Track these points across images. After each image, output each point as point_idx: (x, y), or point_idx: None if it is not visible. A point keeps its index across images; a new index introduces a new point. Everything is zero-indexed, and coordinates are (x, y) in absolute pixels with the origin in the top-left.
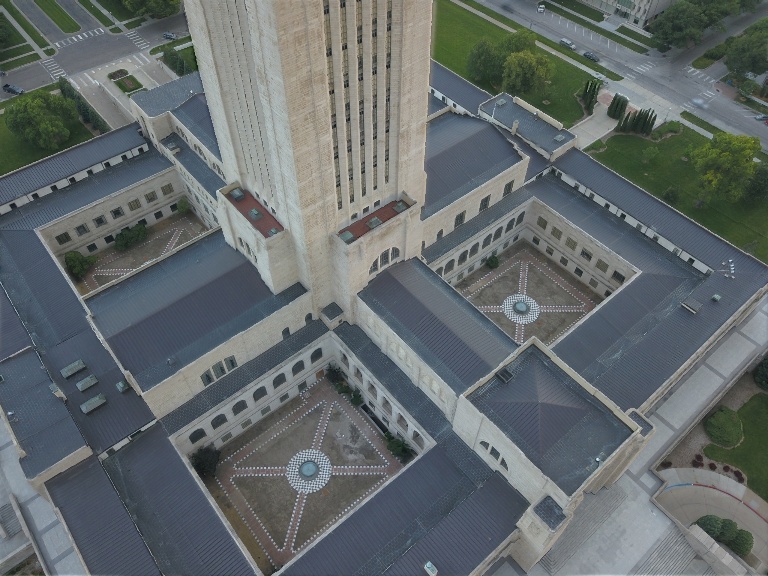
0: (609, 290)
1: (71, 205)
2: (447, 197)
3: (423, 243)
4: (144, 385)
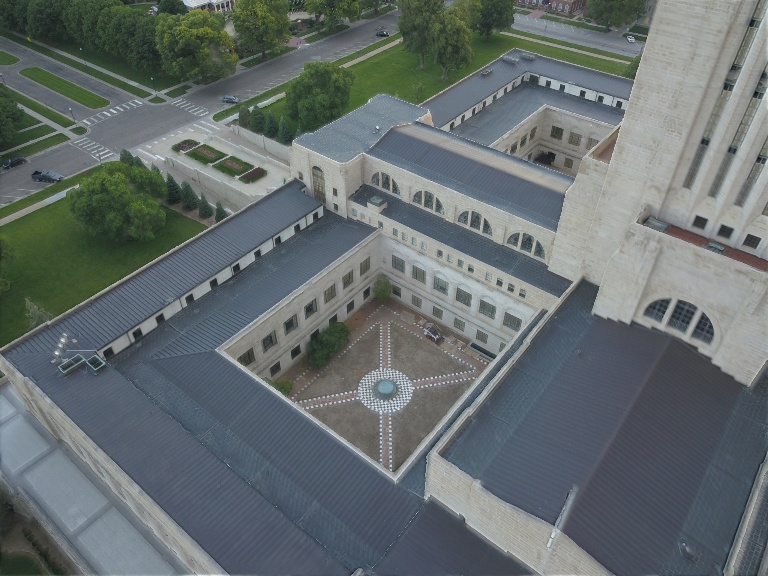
0: None
1: (254, 304)
2: None
3: None
4: None
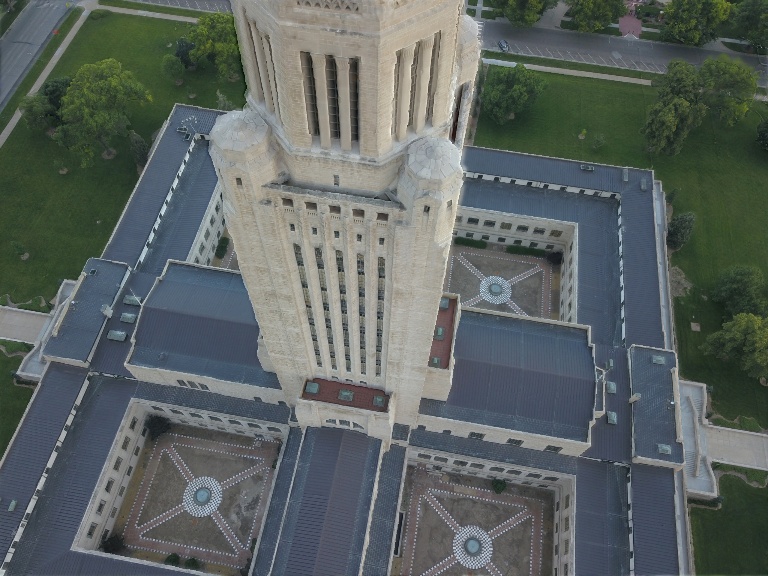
0: None
1: None
2: (475, 411)
3: (424, 426)
4: (135, 357)
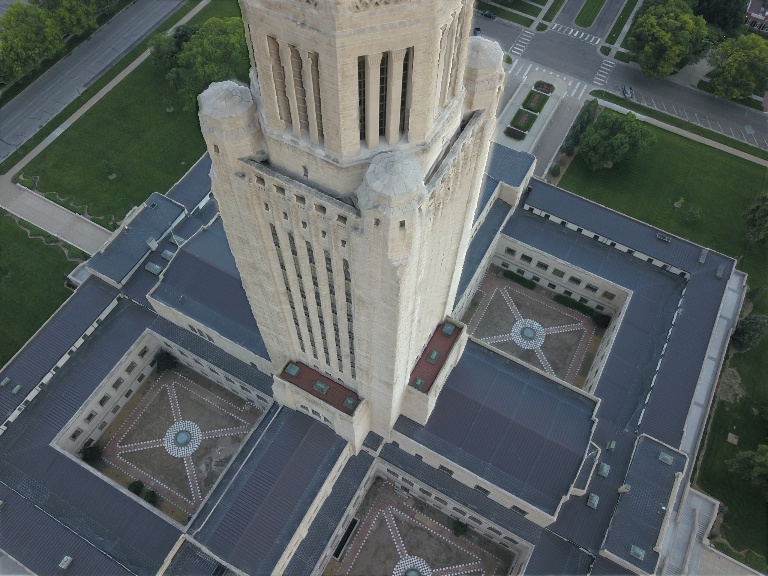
0: None
1: None
2: (450, 445)
3: None
4: (158, 292)
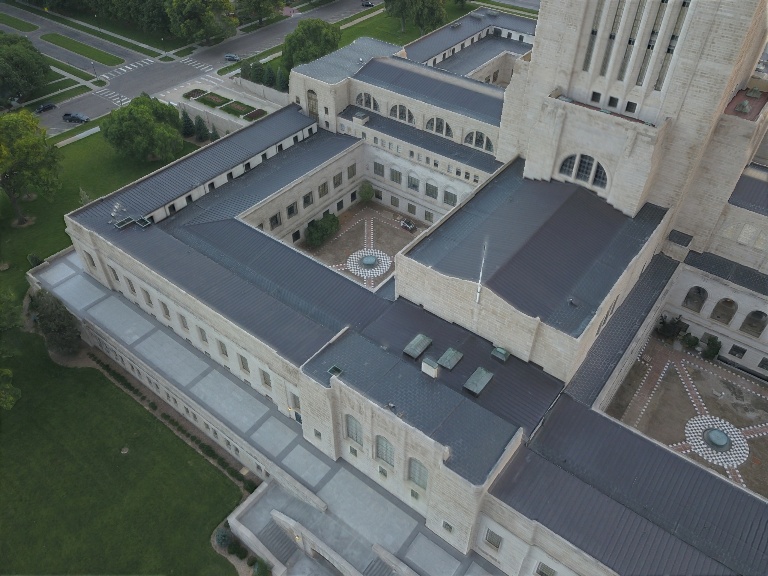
0: None
1: (263, 190)
2: None
3: None
4: None
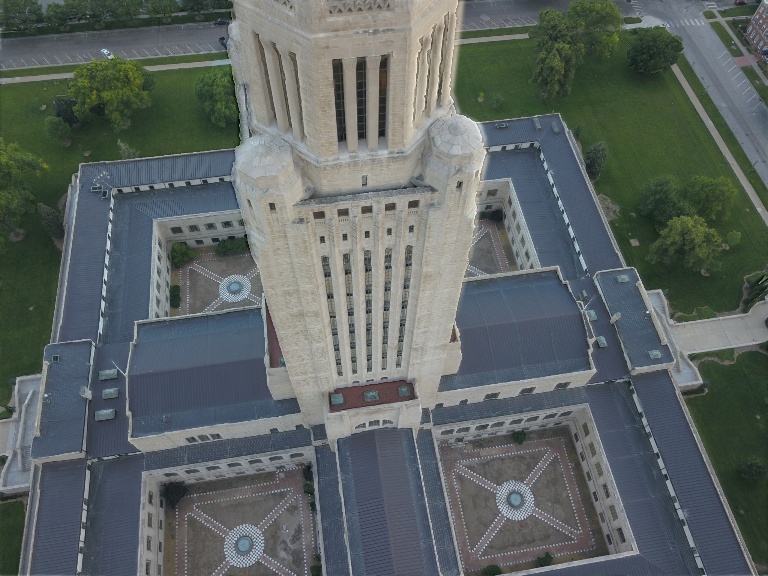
0: (610, 536)
1: (192, 207)
2: (485, 374)
3: (442, 403)
4: (136, 429)
